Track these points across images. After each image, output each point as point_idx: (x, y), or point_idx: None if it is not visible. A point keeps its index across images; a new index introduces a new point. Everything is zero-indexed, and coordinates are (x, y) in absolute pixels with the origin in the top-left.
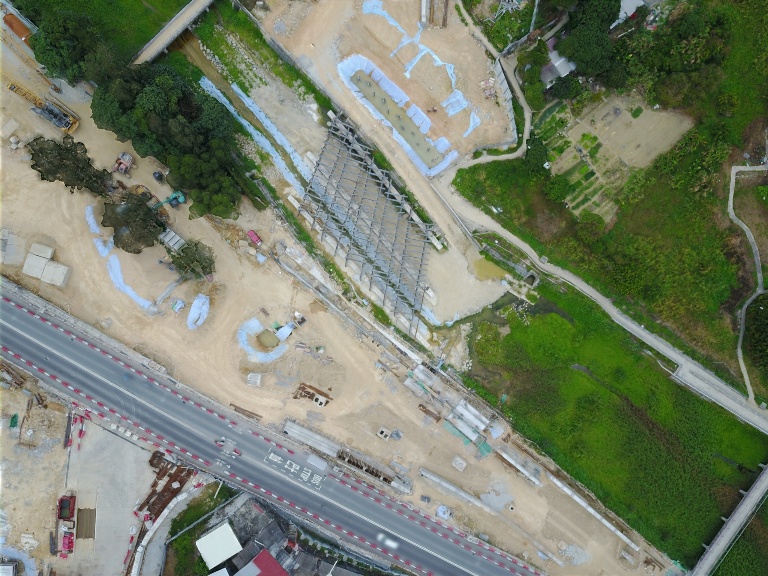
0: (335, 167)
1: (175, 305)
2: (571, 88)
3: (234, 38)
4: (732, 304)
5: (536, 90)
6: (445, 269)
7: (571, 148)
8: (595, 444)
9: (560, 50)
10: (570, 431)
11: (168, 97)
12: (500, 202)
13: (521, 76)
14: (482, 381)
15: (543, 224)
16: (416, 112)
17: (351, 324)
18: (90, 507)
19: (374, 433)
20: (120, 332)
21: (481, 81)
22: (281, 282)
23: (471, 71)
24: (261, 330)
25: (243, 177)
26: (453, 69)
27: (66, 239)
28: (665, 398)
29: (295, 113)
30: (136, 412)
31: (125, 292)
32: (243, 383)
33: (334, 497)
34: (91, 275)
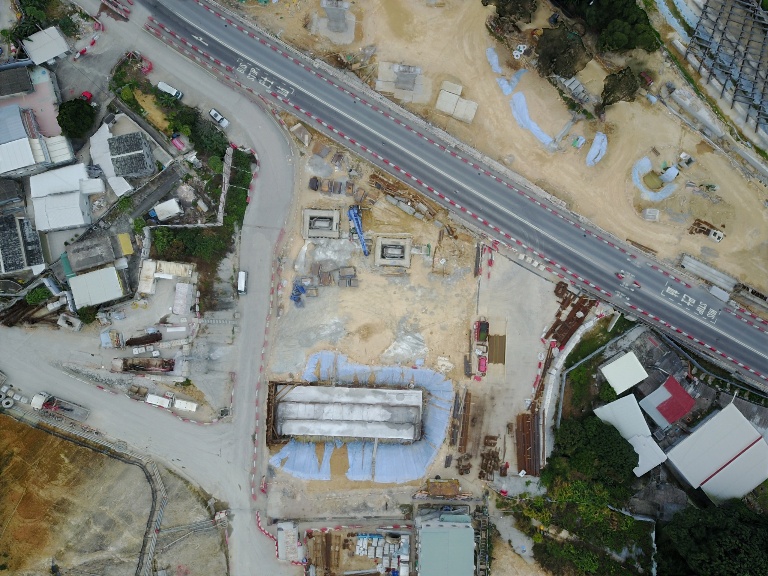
0: (723, 9)
1: (577, 141)
2: None
3: None
4: None
5: None
6: None
7: None
8: None
9: None
10: None
11: None
12: None
13: None
14: None
15: None
16: None
17: (737, 165)
18: (499, 334)
19: None
20: (521, 168)
21: None
22: (670, 123)
23: None
24: (648, 171)
25: None
26: None
27: (470, 79)
28: None
29: None
30: (540, 244)
31: (528, 129)
32: (639, 219)
33: (729, 331)
34: (495, 113)
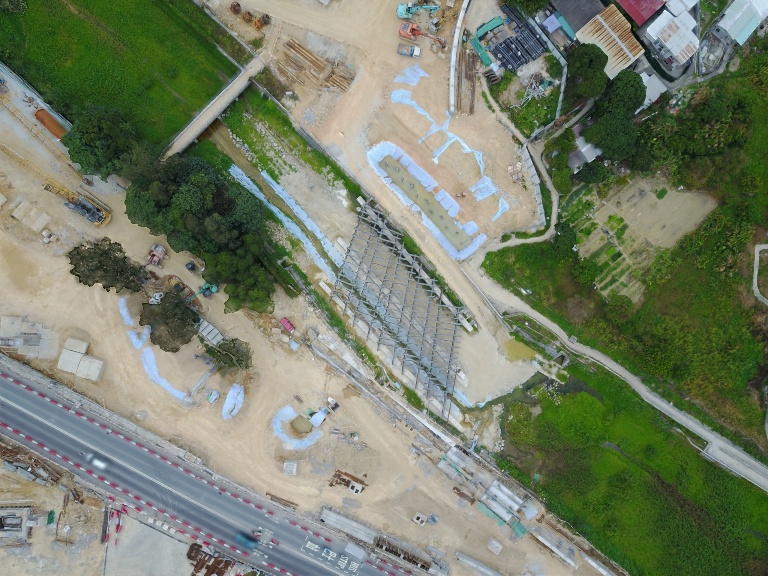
0: (366, 253)
1: (210, 396)
2: (598, 174)
3: (263, 126)
4: (759, 380)
5: (564, 176)
6: (476, 351)
7: (598, 230)
8: (627, 522)
9: (587, 137)
10: (603, 510)
11: (204, 195)
12: (529, 284)
13: (548, 161)
14: (514, 461)
15: (574, 309)
16: (445, 197)
17: (384, 408)
18: None
19: (410, 518)
20: (155, 424)
21: (508, 166)
22: (314, 368)
23: (499, 157)
24: (295, 416)
25: (275, 266)
26: (482, 156)
27: (100, 332)
28: (695, 474)
29: (325, 199)
30: (173, 505)
31: (160, 384)
32: (279, 472)
33: None
34: (125, 368)
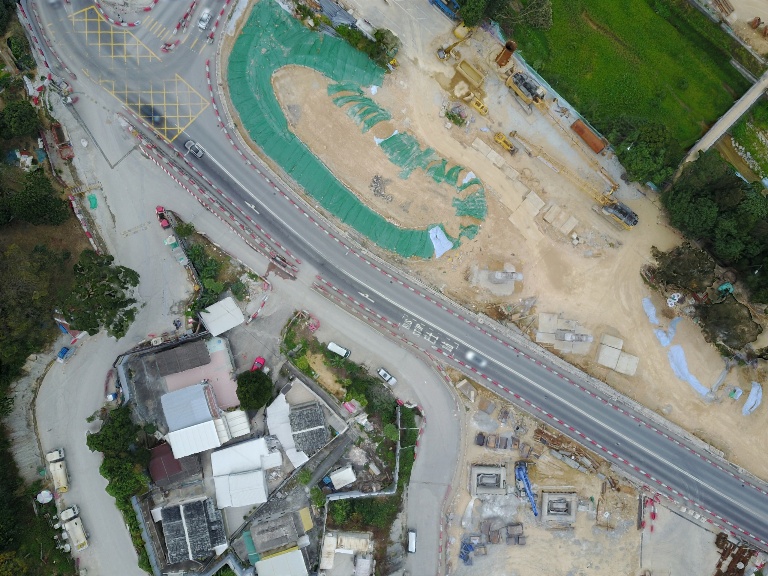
0: None
1: (735, 393)
2: None
3: (763, 135)
4: None
5: None
6: None
7: None
8: None
9: None
10: None
11: None
12: None
13: None
14: None
15: None
16: None
17: None
18: None
19: None
20: (679, 418)
21: None
22: None
23: None
24: None
25: None
26: None
27: (628, 330)
28: None
29: None
30: (699, 495)
31: (687, 380)
32: None
33: None
34: (653, 364)
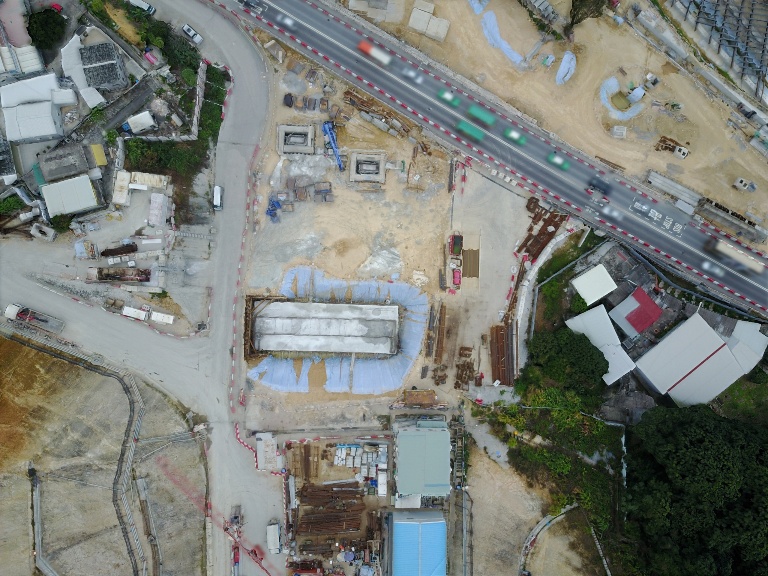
0: None
1: (547, 59)
2: None
3: None
4: None
5: None
6: None
7: None
8: None
9: None
10: None
11: None
12: None
13: None
14: None
15: None
16: None
17: None
18: (473, 248)
19: (731, 184)
20: (493, 87)
21: None
22: (636, 44)
23: None
24: (616, 91)
25: None
26: None
27: None
28: None
29: None
30: (512, 161)
31: (500, 47)
32: (607, 136)
33: (694, 245)
34: (467, 32)
